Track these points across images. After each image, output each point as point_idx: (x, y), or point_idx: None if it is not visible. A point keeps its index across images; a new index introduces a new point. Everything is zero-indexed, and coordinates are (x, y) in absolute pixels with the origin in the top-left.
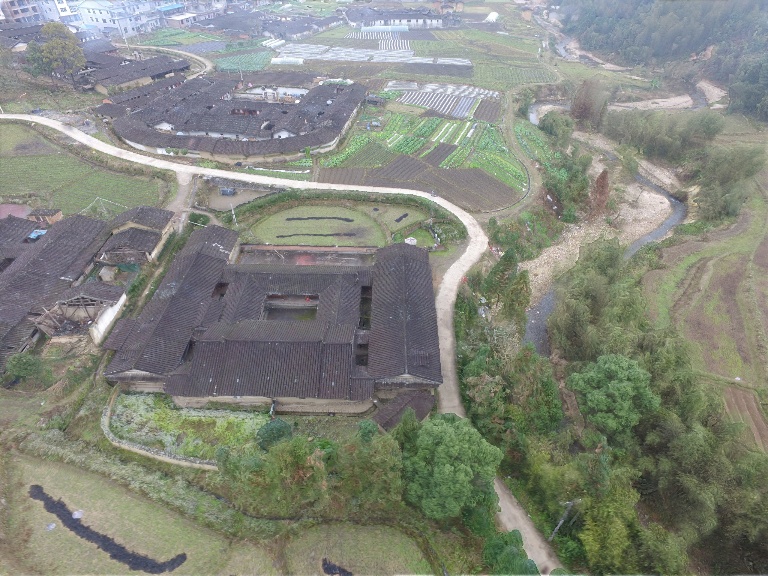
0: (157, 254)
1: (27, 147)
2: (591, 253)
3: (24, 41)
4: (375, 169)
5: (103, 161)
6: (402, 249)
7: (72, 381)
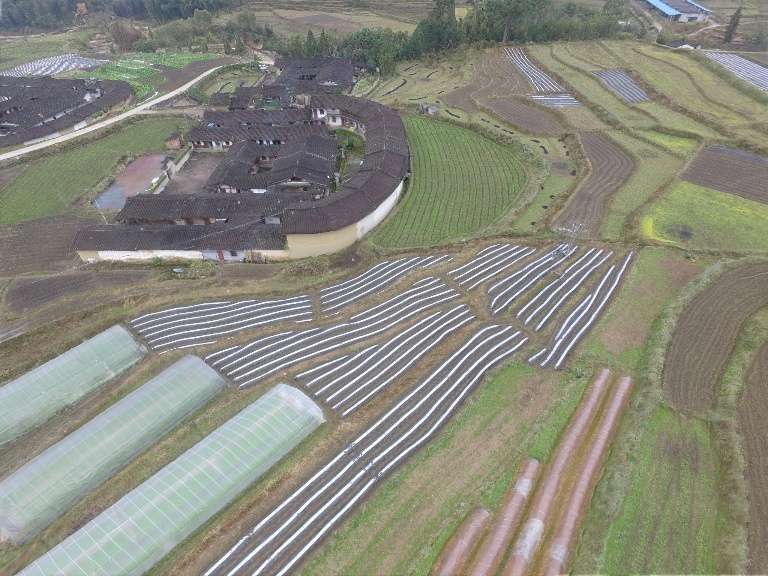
0: None
1: None
2: (296, 41)
3: None
4: None
5: (79, 142)
6: None
7: None
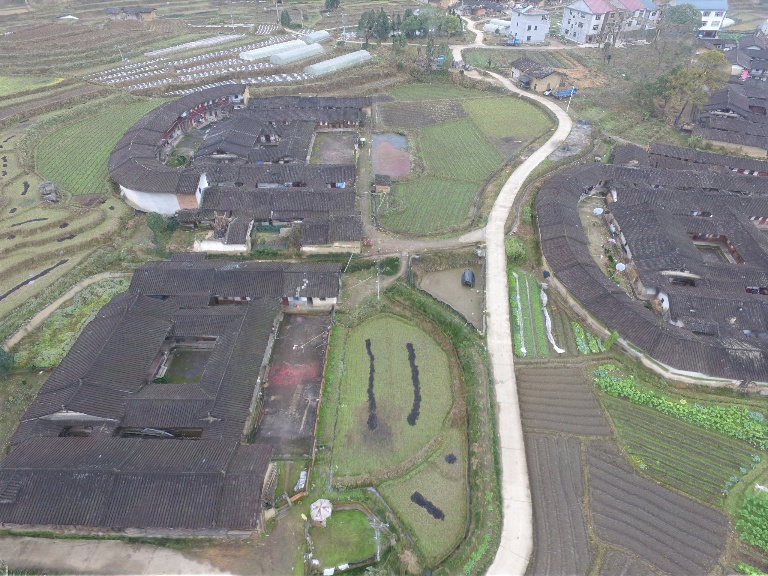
0: (314, 252)
1: (510, 141)
2: None
3: (749, 65)
4: (620, 457)
5: None
6: (244, 473)
7: (155, 250)
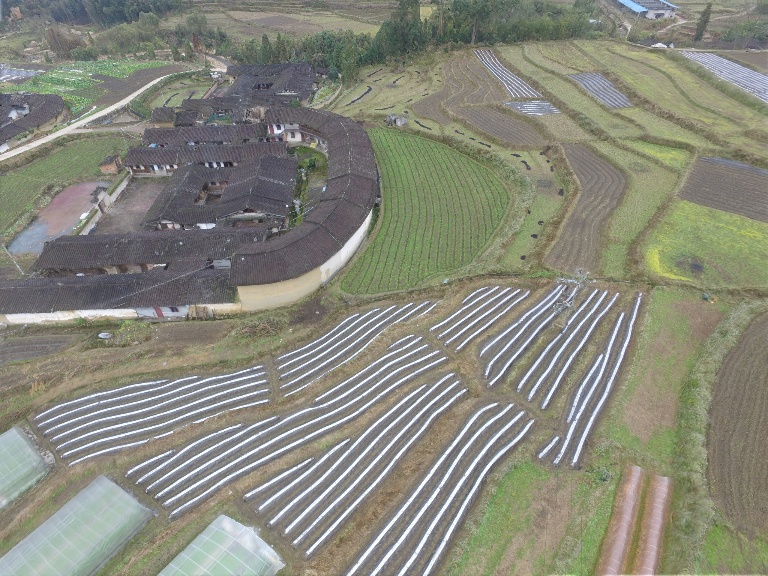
0: None
1: None
2: (251, 45)
3: None
4: None
5: None
6: None
7: None
